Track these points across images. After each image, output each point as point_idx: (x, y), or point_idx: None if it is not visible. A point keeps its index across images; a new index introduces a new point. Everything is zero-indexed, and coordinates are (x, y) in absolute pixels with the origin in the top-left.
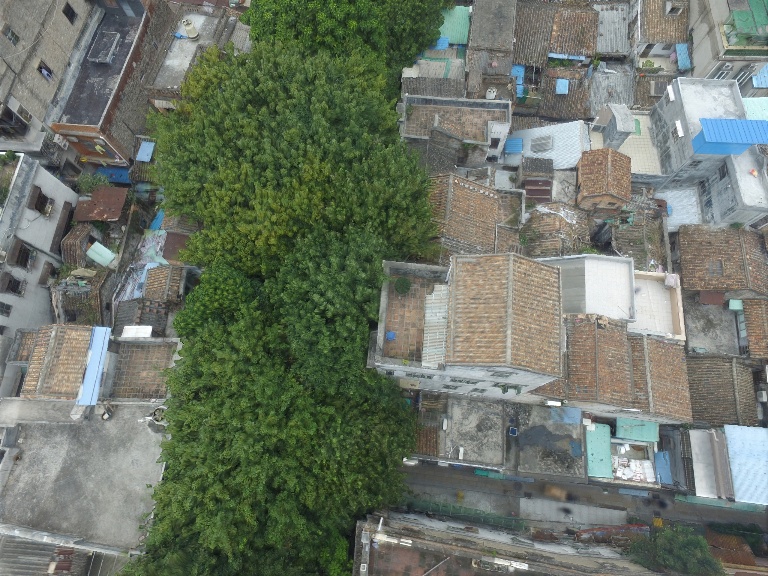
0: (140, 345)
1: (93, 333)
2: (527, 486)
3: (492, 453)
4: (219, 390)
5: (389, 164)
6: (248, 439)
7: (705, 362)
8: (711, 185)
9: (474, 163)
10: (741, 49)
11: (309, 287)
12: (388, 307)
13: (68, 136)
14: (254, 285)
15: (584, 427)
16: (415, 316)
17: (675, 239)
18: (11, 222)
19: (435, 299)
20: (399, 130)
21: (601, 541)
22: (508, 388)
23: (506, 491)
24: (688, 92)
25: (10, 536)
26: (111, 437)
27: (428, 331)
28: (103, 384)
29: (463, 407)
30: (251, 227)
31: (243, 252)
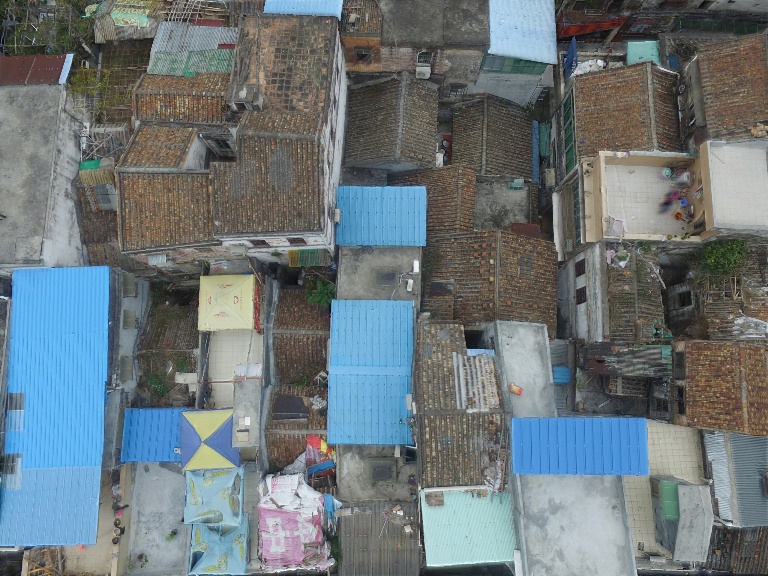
0: None
1: None
2: None
3: None
4: None
5: None
6: None
7: None
8: None
9: None
10: None
11: None
12: None
13: None
14: None
15: None
16: None
17: None
18: None
19: None
20: None
21: (611, 11)
22: None
23: None
24: (609, 571)
25: None
26: None
27: None
28: None
29: None
30: None
31: None
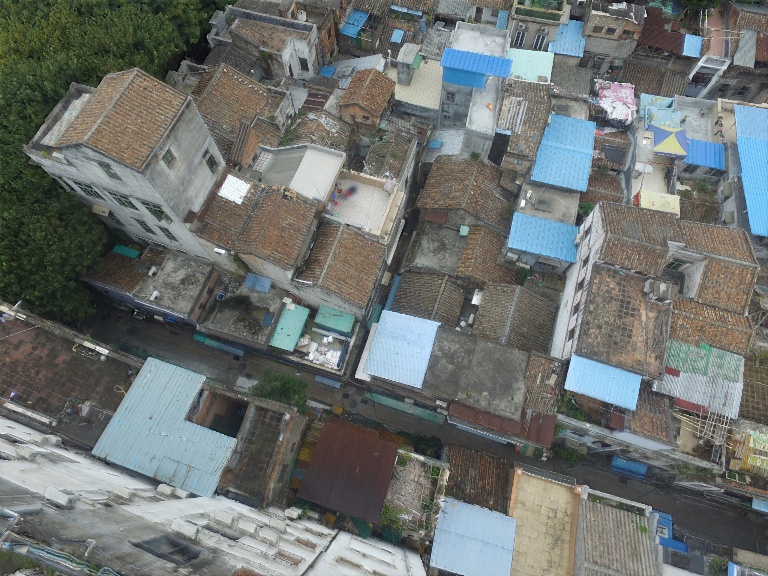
0: None
1: None
2: (250, 368)
3: (185, 304)
4: None
5: None
6: None
7: (424, 278)
8: None
9: (279, 77)
10: (528, 9)
11: None
12: None
13: None
14: None
15: (283, 304)
16: None
17: None
18: None
19: (78, 103)
20: (210, 32)
21: None
22: None
23: (230, 369)
24: (465, 36)
25: None
26: None
27: (58, 124)
28: None
29: (176, 263)
30: None
31: None
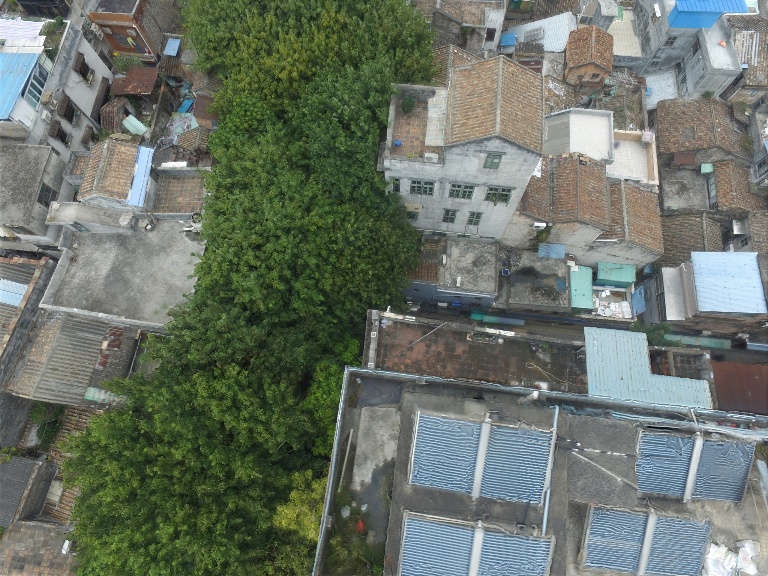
0: (176, 177)
1: (139, 150)
2: None
3: (486, 284)
4: (250, 188)
5: (396, 12)
6: (277, 215)
7: (679, 219)
8: (686, 63)
9: (472, 51)
10: None
11: (328, 98)
12: (395, 125)
13: (103, 27)
14: (277, 123)
15: (568, 267)
16: (419, 132)
17: (654, 116)
18: (60, 78)
19: (436, 101)
20: None
21: None
22: (499, 200)
23: None
24: None
25: (69, 316)
26: (153, 244)
27: (430, 124)
28: (146, 201)
29: (461, 247)
30: (276, 63)
31: (268, 90)
